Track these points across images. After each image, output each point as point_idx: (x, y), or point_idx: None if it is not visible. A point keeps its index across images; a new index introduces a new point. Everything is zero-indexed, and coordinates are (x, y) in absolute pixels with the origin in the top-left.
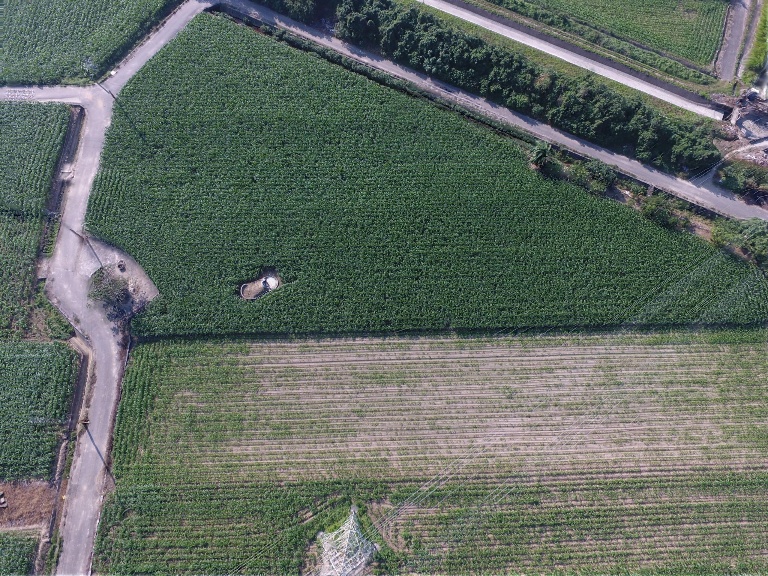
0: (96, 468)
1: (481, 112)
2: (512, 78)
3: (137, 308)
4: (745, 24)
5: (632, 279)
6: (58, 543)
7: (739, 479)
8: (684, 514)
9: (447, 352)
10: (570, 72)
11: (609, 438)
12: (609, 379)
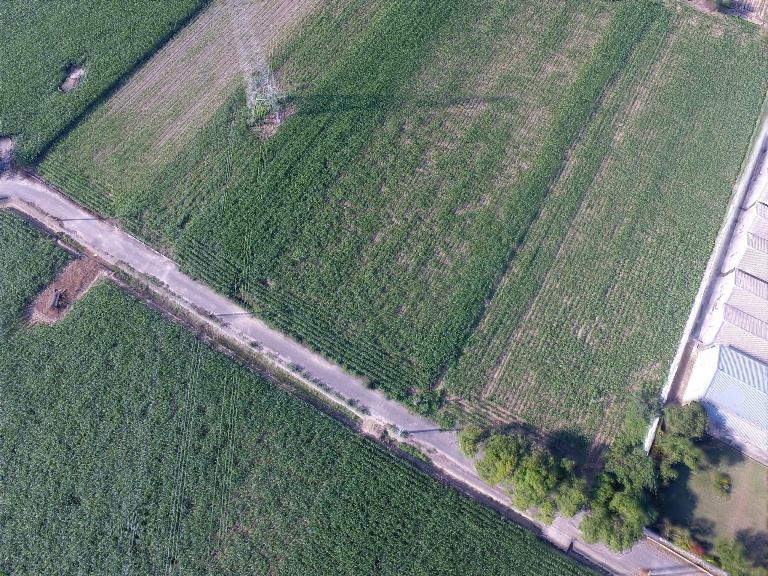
0: (94, 225)
1: None
2: None
3: (8, 160)
4: None
5: None
6: (121, 265)
7: None
8: None
9: (210, 14)
10: None
11: None
12: None
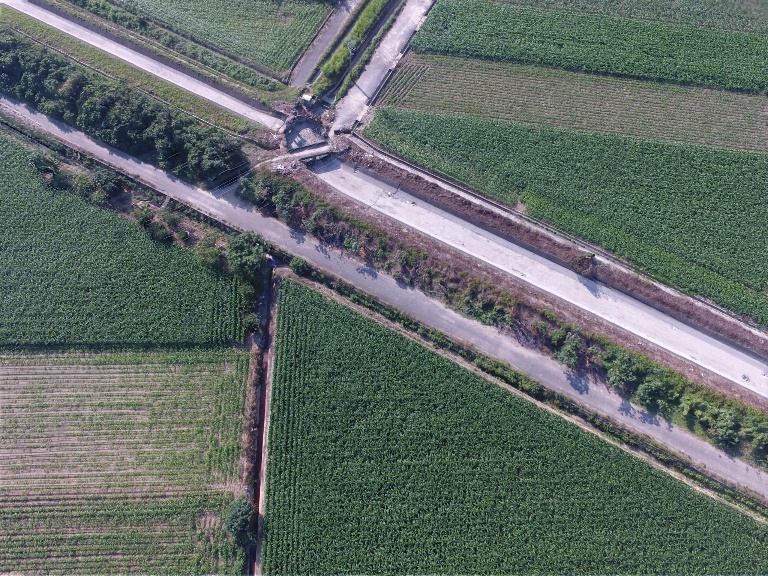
0: None
1: (16, 118)
2: (39, 83)
3: None
4: (341, 29)
5: (94, 295)
6: None
7: (128, 509)
8: (53, 547)
9: None
10: (129, 77)
11: (7, 464)
12: (35, 401)
